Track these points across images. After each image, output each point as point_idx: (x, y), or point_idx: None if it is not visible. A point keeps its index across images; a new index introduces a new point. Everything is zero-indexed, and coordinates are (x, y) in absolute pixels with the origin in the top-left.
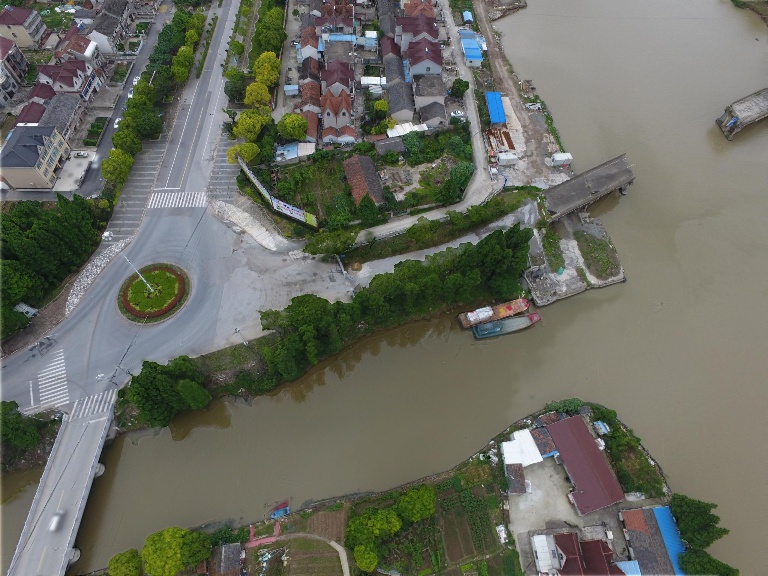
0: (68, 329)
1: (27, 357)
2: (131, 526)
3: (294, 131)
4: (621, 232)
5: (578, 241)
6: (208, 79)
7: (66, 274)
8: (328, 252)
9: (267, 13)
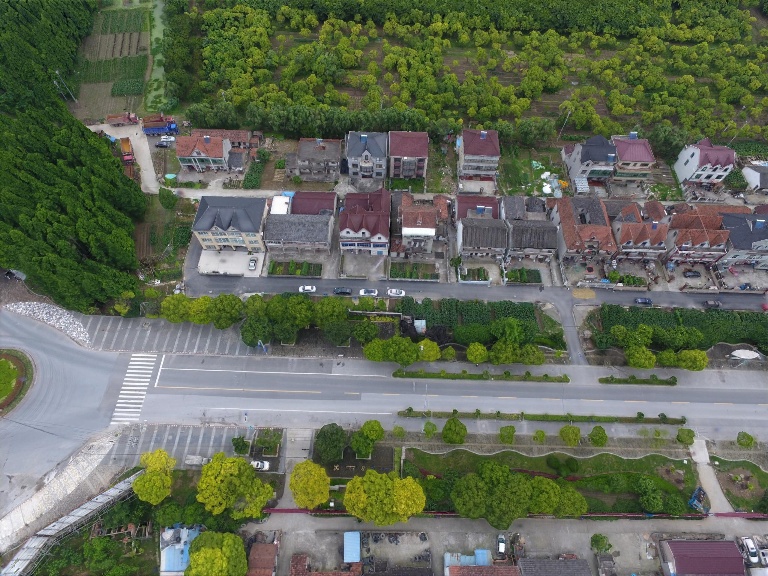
0: None
1: None
2: None
3: (189, 567)
4: None
5: None
6: (392, 390)
7: None
8: None
9: (551, 483)
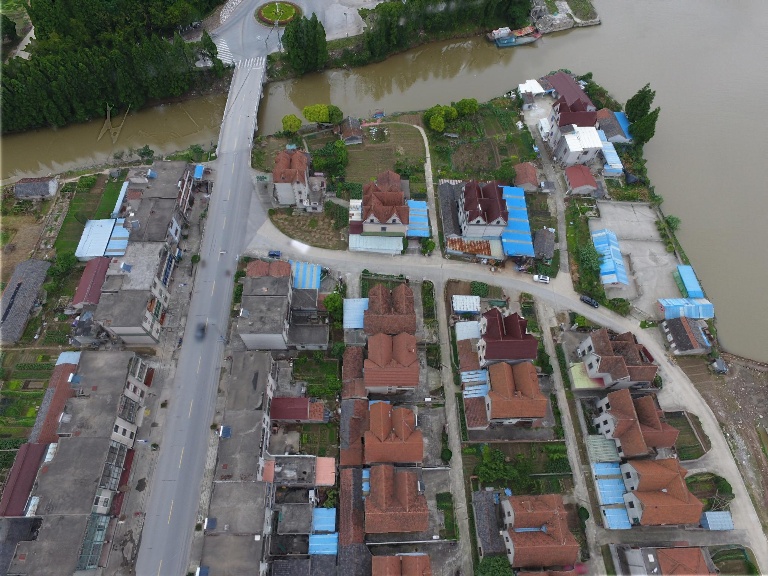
0: (224, 30)
1: None
2: (282, 130)
3: None
4: (598, 1)
5: (568, 2)
6: None
7: (215, 5)
8: None
9: None
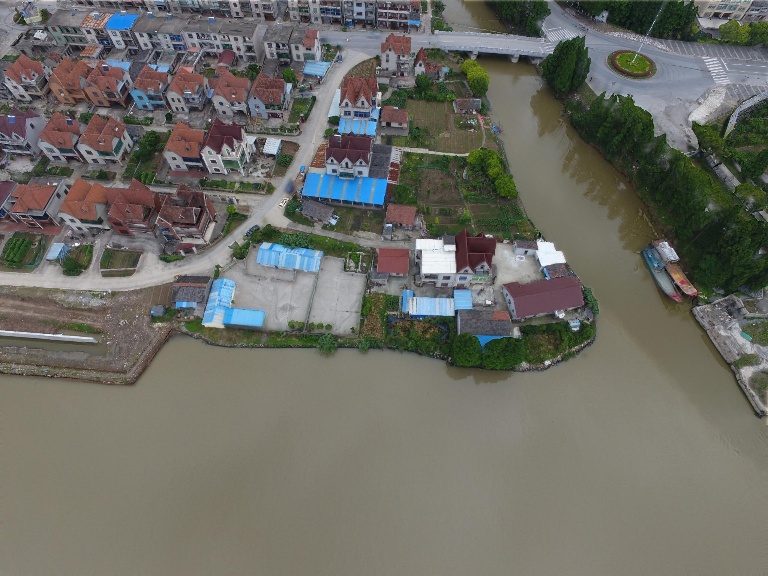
0: (596, 35)
1: (575, 24)
2: None
3: None
4: None
5: None
6: None
7: (634, 29)
8: (698, 135)
9: None
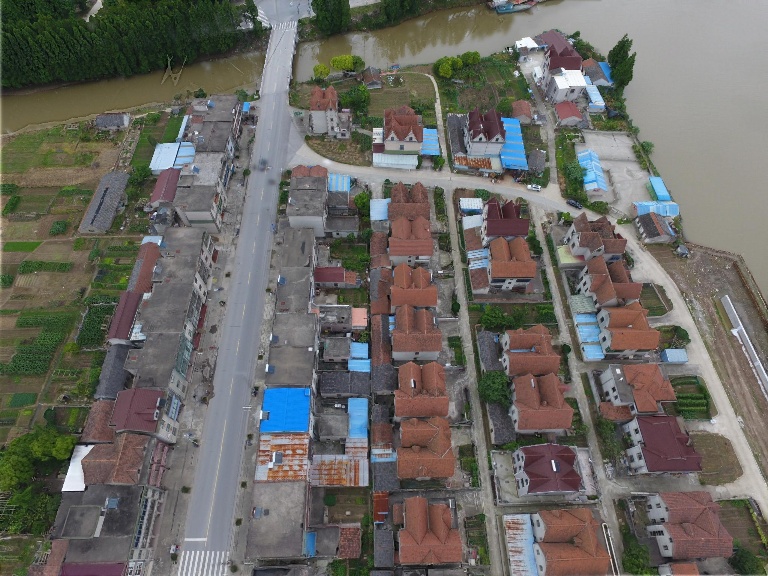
0: (261, 0)
1: None
2: None
3: None
4: None
5: None
6: None
7: None
8: None
9: None
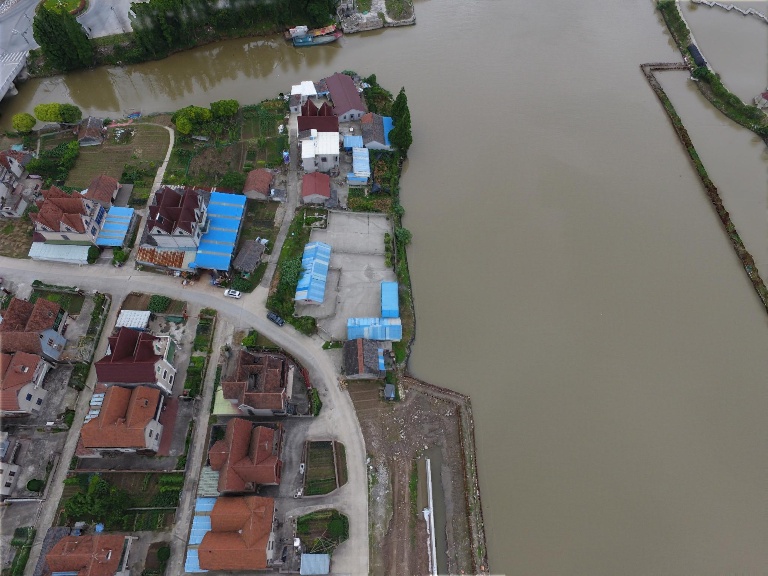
0: None
1: None
2: (36, 129)
3: None
4: (423, 0)
5: (386, 0)
6: None
7: None
8: None
9: None
